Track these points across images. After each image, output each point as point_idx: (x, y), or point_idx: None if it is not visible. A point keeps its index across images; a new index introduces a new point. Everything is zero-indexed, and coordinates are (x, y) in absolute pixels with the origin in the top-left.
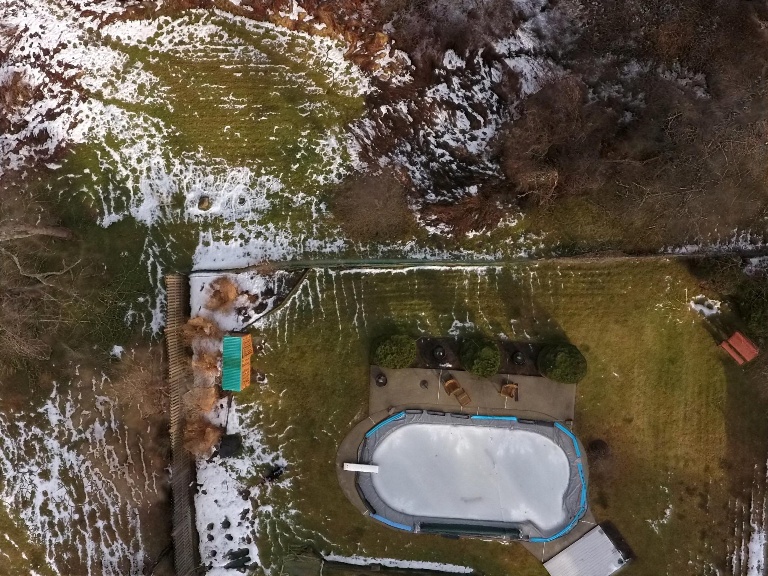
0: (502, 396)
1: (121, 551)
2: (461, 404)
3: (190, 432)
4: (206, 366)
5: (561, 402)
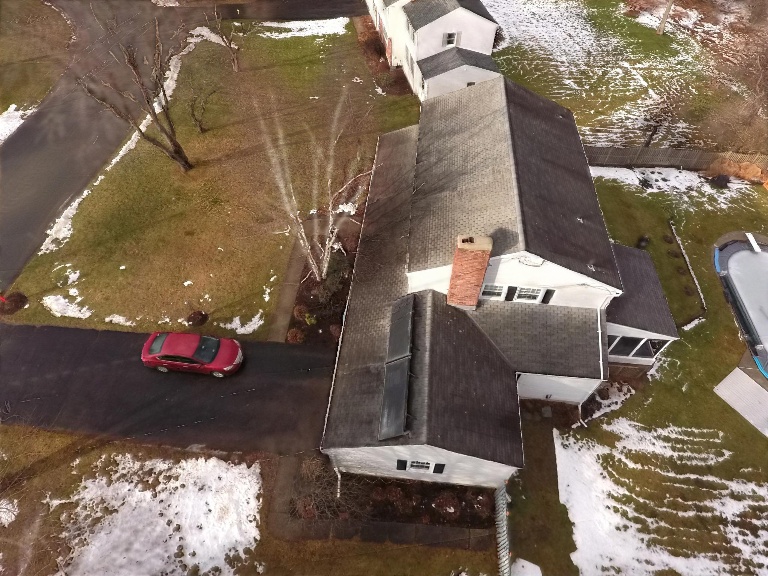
0: None
1: (621, 141)
2: None
3: (729, 162)
4: (764, 177)
5: None
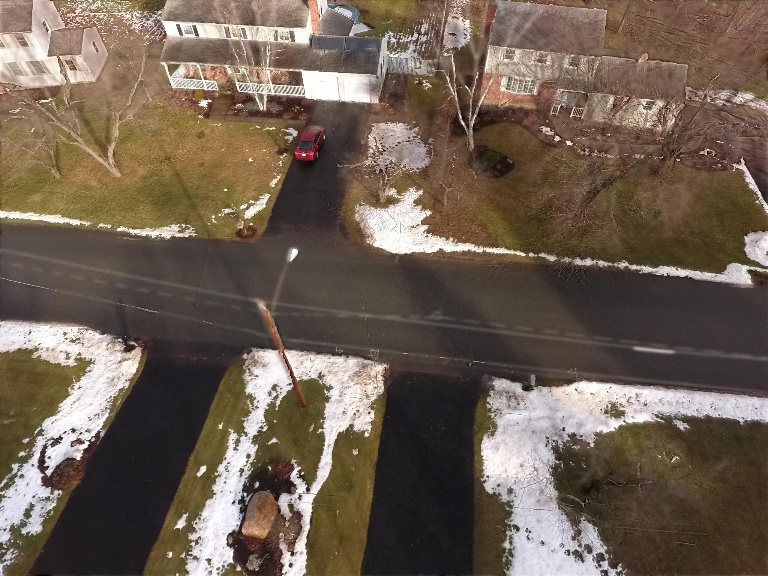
0: (329, 0)
1: None
2: None
3: None
4: None
5: None
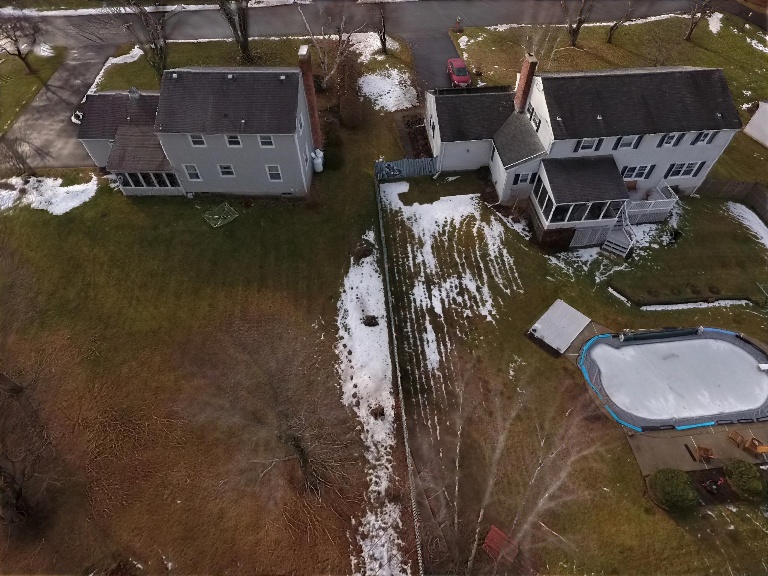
0: None
1: None
2: (736, 432)
3: None
4: None
5: (646, 451)
